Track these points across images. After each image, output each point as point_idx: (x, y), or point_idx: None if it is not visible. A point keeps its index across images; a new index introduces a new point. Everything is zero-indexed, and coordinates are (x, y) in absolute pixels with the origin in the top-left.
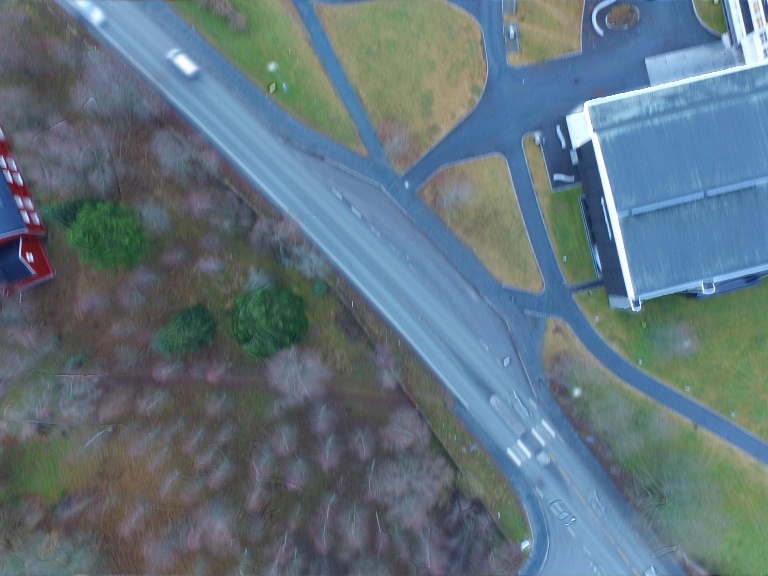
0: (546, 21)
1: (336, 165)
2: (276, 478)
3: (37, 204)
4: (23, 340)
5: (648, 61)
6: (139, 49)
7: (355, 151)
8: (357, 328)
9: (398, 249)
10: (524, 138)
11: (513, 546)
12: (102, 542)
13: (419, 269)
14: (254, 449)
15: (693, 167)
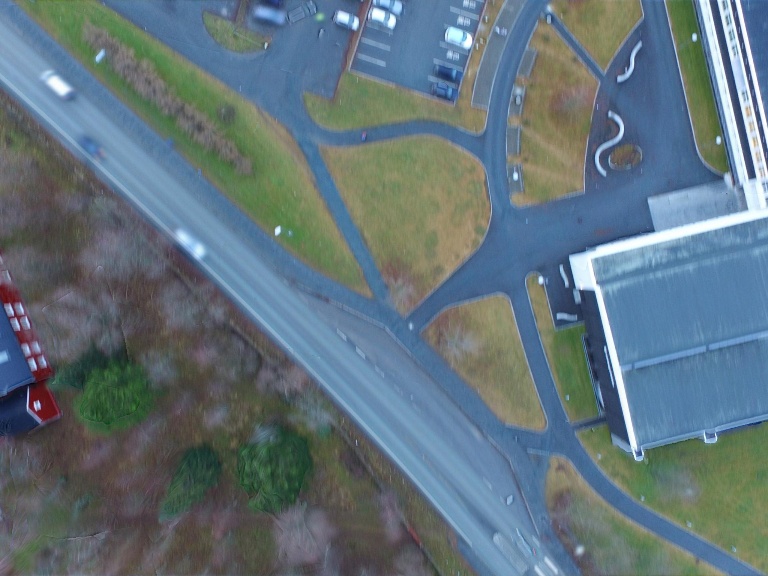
0: (549, 162)
1: (341, 307)
2: None
3: (44, 346)
4: None
5: (651, 200)
6: (145, 192)
7: (360, 293)
8: (361, 468)
9: (402, 389)
10: (527, 277)
11: None
12: None
13: (423, 409)
14: None
15: (695, 320)
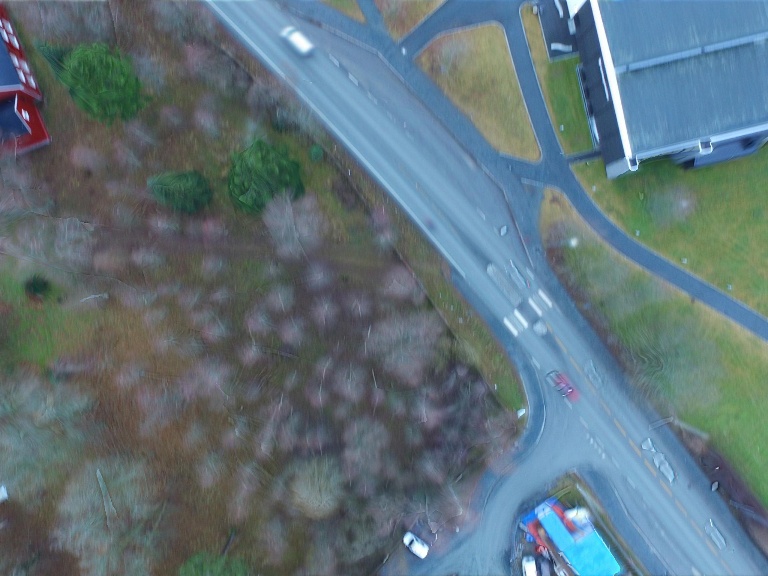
0: None
1: (333, 31)
2: (272, 348)
3: (33, 68)
4: (19, 204)
5: None
6: None
7: (352, 17)
8: (354, 195)
9: (395, 116)
10: (522, 7)
11: (510, 414)
12: (98, 410)
13: (416, 137)
14: (250, 317)
15: (691, 24)
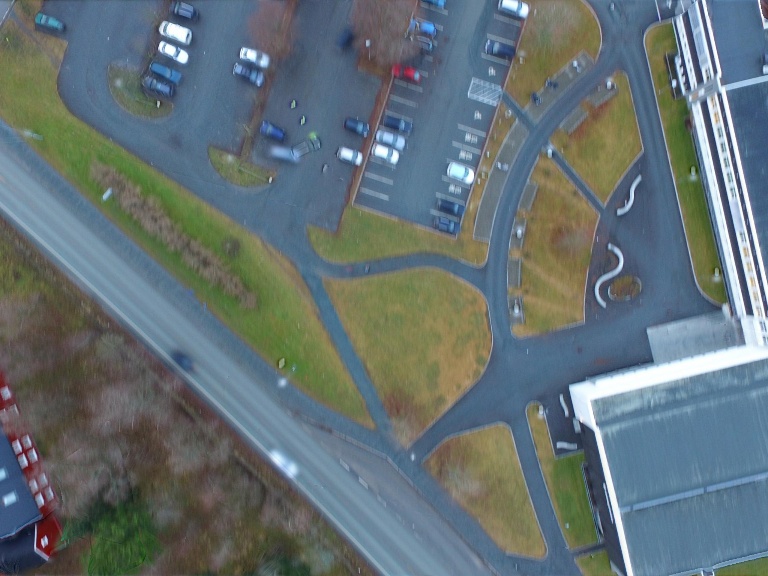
0: (550, 294)
1: (344, 437)
2: None
3: (51, 477)
4: None
5: (650, 331)
6: (151, 326)
7: (362, 424)
8: None
9: (404, 518)
10: (528, 407)
11: None
12: None
13: (425, 538)
14: None
15: (693, 462)
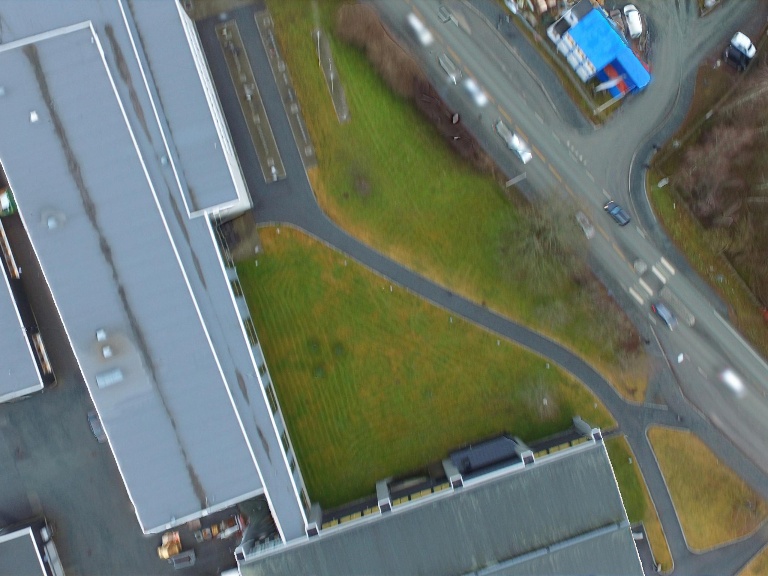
0: None
1: None
2: None
3: None
4: None
5: None
6: None
7: None
8: None
9: None
10: (672, 569)
11: None
12: None
13: (767, 440)
14: None
15: (559, 573)
